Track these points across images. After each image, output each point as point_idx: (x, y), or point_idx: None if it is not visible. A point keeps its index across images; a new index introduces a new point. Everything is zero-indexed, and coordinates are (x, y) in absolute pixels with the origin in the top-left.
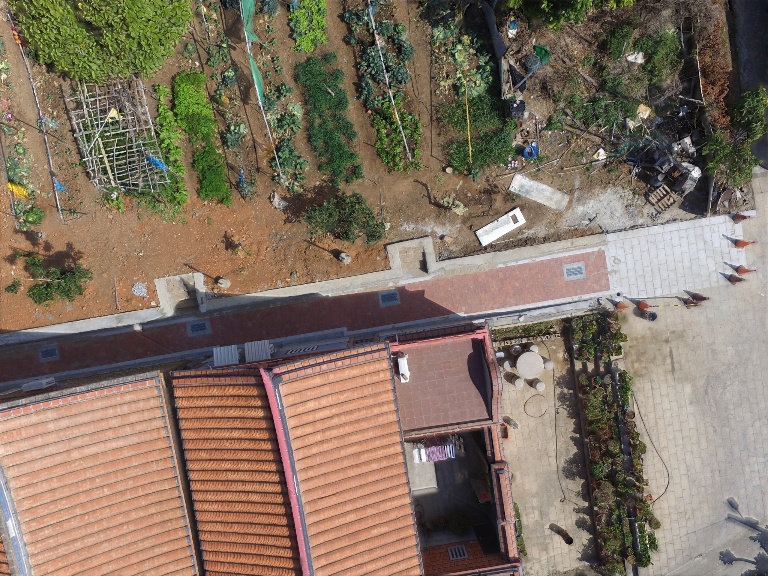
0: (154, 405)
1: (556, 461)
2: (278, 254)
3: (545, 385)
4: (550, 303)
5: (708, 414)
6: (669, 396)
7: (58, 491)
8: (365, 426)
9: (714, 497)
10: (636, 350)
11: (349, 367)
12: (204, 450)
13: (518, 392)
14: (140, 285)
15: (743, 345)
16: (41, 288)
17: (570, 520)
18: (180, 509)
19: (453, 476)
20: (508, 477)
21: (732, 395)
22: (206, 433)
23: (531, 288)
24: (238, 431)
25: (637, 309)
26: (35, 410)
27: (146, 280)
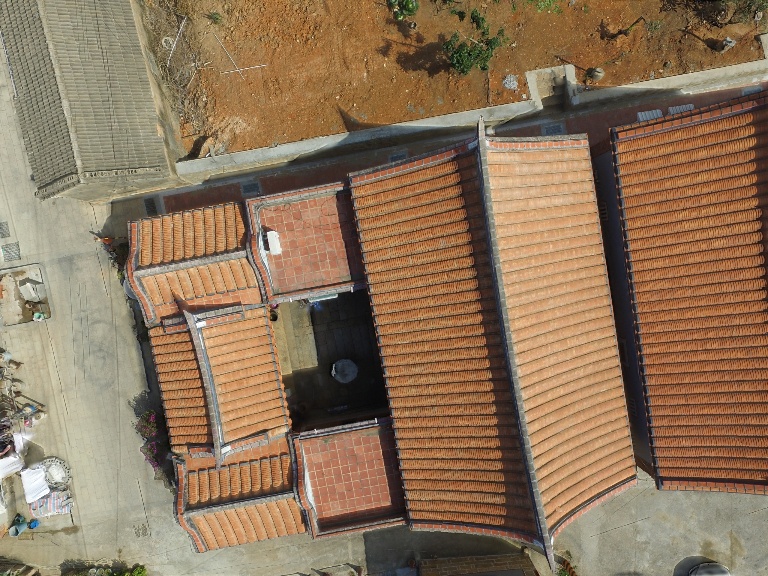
0: (584, 167)
1: None
2: (652, 44)
3: None
4: None
5: None
6: None
7: (521, 237)
8: None
9: None
10: None
11: None
12: (651, 204)
13: None
14: (512, 77)
15: None
16: (464, 52)
17: None
18: (605, 276)
19: None
20: None
21: None
22: (657, 184)
23: None
24: (707, 173)
25: None
26: (509, 149)
27: (518, 72)
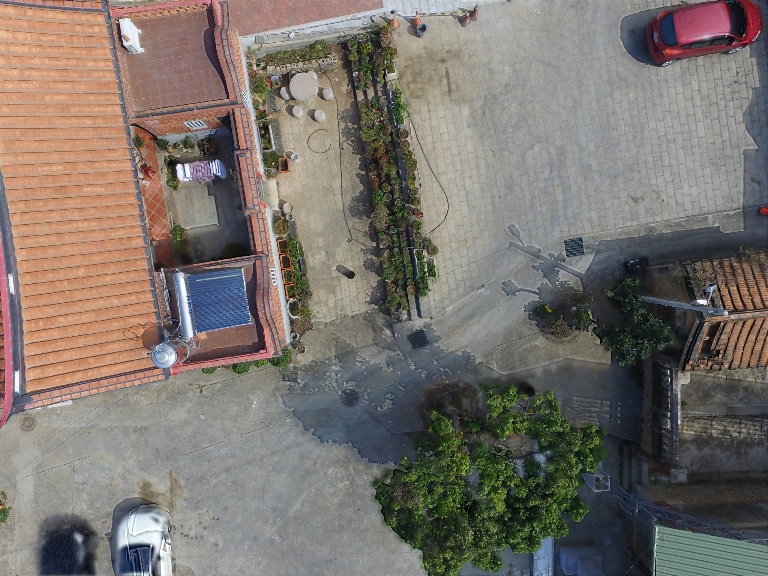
0: None
1: (342, 199)
2: None
3: (329, 119)
4: (323, 23)
5: (486, 137)
6: (446, 119)
7: None
8: (76, 78)
9: (495, 224)
10: (411, 70)
11: (54, 10)
12: None
13: (301, 126)
14: None
15: (520, 65)
16: None
17: (358, 261)
18: None
19: (235, 213)
20: (251, 164)
21: (510, 117)
22: None
23: (304, 8)
24: None
25: (411, 27)
26: None
27: None
